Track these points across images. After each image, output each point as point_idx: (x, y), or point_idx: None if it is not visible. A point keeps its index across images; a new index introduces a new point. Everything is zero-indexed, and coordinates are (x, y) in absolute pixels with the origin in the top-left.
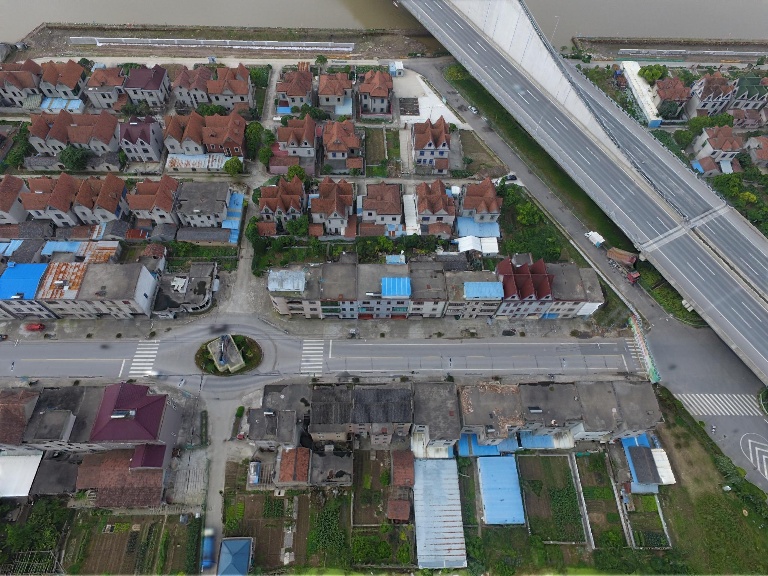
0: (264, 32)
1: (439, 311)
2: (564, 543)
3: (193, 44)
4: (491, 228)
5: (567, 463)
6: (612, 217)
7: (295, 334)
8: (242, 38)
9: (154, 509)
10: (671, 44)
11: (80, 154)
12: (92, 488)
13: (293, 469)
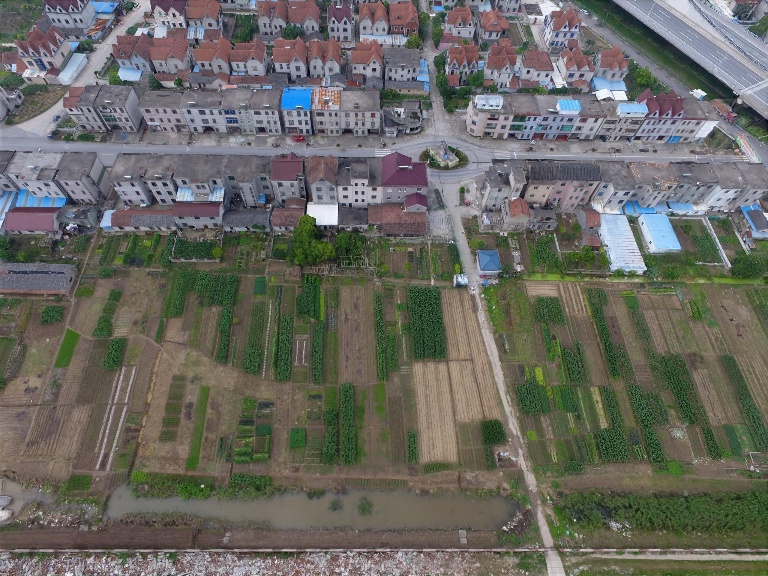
0: None
1: (594, 131)
2: (709, 264)
3: None
4: (619, 85)
5: (702, 223)
6: (715, 73)
7: (487, 148)
8: None
9: (423, 236)
10: None
11: (299, 30)
12: (378, 224)
13: (521, 208)
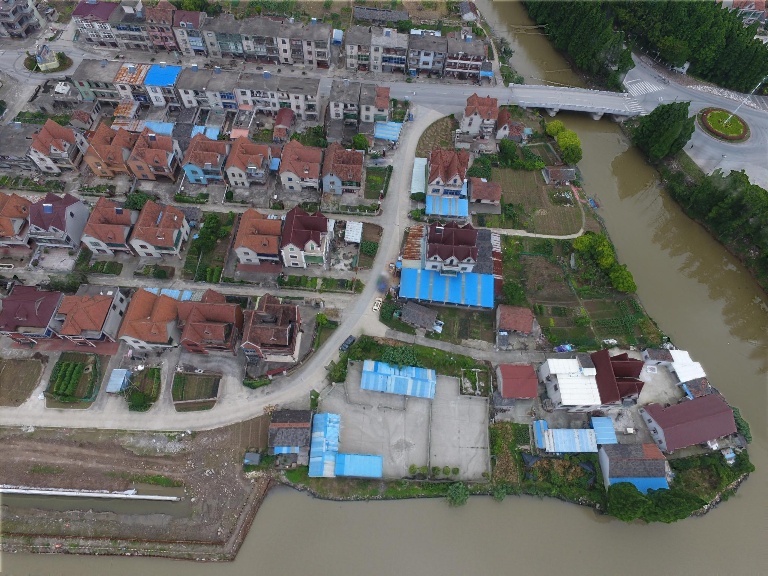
0: None
1: None
2: None
3: None
4: None
5: None
6: None
7: None
8: None
9: None
10: None
11: (128, 196)
12: None
13: None
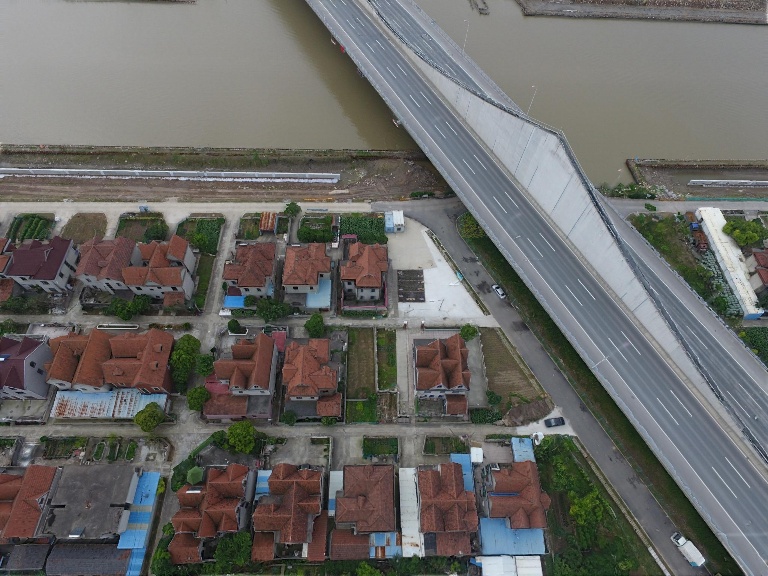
0: (221, 156)
1: None
2: None
3: (125, 175)
4: (531, 538)
5: None
6: (721, 539)
7: None
8: (192, 164)
9: None
10: (756, 169)
11: None
12: None
13: None
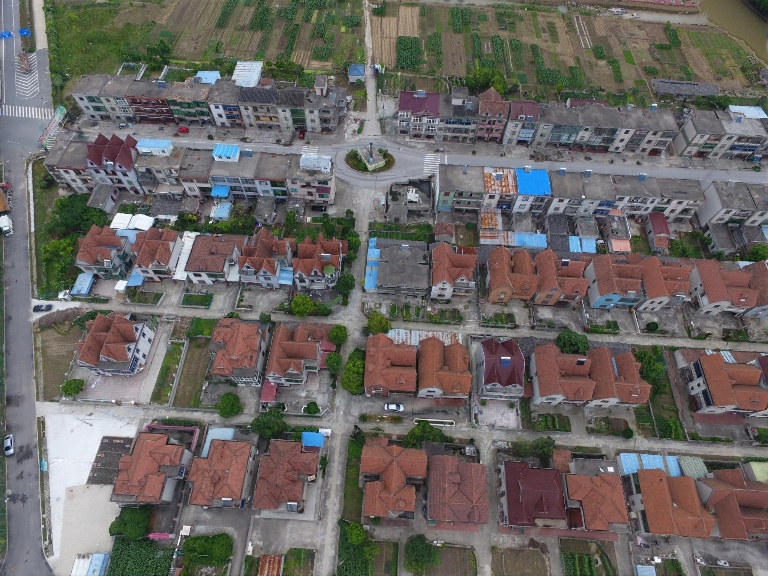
0: None
1: None
2: None
3: None
4: None
5: None
6: None
7: None
8: None
9: None
10: None
11: (561, 335)
12: None
13: None
